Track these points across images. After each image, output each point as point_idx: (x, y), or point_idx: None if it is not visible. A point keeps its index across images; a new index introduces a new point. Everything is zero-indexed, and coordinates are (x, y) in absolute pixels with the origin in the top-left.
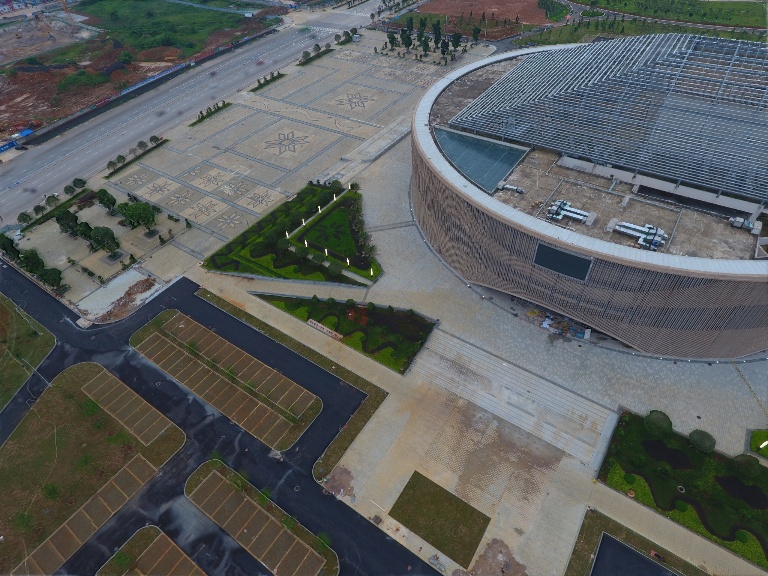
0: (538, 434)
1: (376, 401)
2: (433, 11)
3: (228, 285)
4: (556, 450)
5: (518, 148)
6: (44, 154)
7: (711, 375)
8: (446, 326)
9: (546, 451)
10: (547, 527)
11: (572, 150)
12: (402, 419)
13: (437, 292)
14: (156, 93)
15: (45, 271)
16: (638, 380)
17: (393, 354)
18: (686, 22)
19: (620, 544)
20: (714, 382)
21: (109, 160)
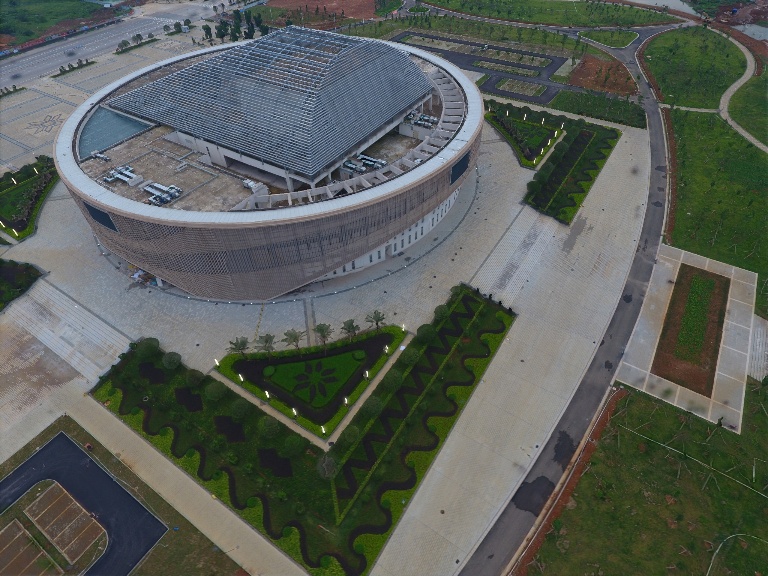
0: (69, 360)
1: None
2: (279, 5)
3: None
4: (74, 372)
5: (150, 124)
6: None
7: (237, 313)
8: (52, 277)
9: (66, 373)
10: (19, 428)
11: (178, 125)
12: None
13: (67, 250)
14: None
15: None
16: (174, 317)
17: None
18: (495, 19)
19: (67, 439)
20: (234, 318)
21: None
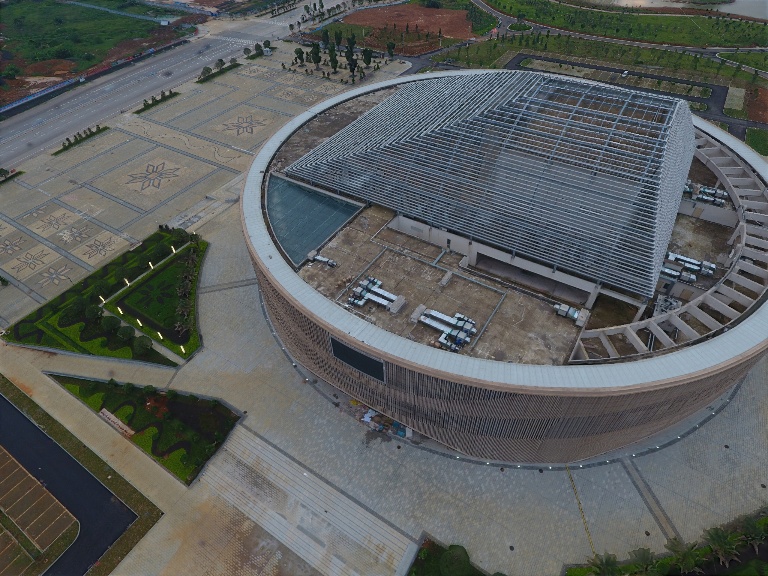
0: (324, 571)
1: (145, 525)
2: (358, 22)
3: (23, 362)
4: None
5: (354, 203)
6: None
7: (539, 486)
8: (252, 421)
9: None
10: None
11: (406, 210)
12: (168, 551)
13: (255, 374)
14: (30, 114)
15: None
16: (454, 495)
17: (183, 459)
18: (613, 38)
19: None
20: (540, 496)
21: None
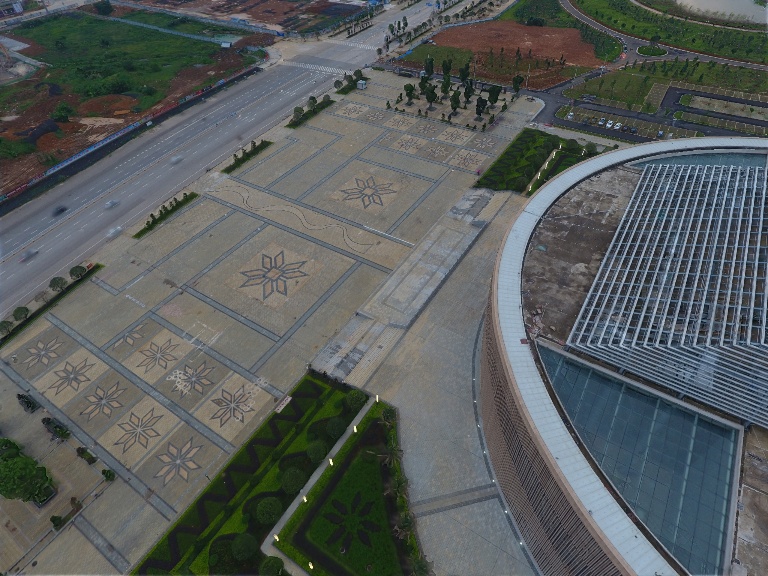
0: None
1: None
2: (453, 43)
3: None
4: None
5: (714, 419)
6: None
7: None
8: None
9: None
10: None
11: None
12: None
13: None
14: (95, 173)
15: None
16: None
17: None
18: None
19: None
20: None
21: (7, 307)
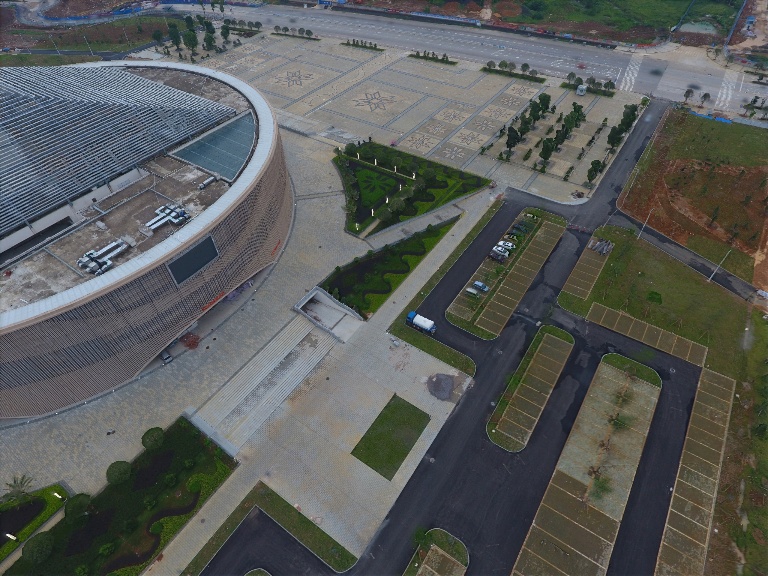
0: None
1: None
2: None
3: None
4: None
5: None
6: (316, 14)
7: None
8: None
9: None
10: None
11: None
12: None
13: None
14: (413, 24)
15: (156, 31)
16: None
17: None
18: None
19: None
20: None
21: None
